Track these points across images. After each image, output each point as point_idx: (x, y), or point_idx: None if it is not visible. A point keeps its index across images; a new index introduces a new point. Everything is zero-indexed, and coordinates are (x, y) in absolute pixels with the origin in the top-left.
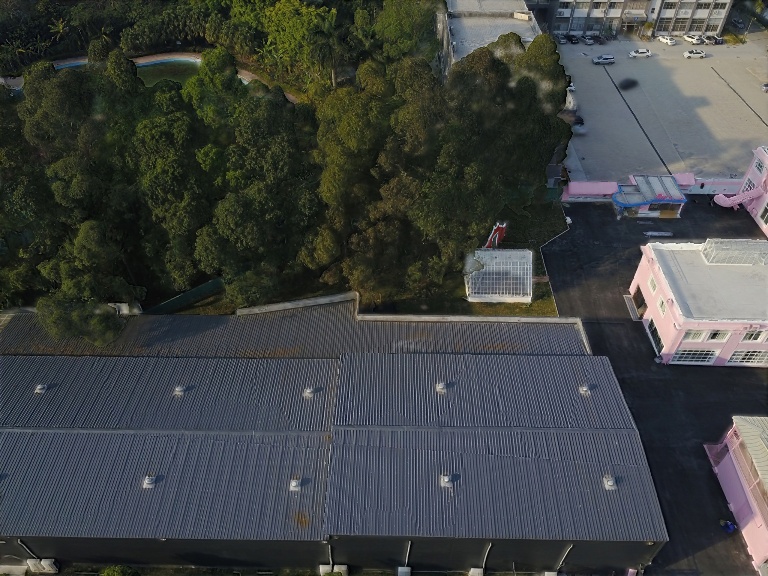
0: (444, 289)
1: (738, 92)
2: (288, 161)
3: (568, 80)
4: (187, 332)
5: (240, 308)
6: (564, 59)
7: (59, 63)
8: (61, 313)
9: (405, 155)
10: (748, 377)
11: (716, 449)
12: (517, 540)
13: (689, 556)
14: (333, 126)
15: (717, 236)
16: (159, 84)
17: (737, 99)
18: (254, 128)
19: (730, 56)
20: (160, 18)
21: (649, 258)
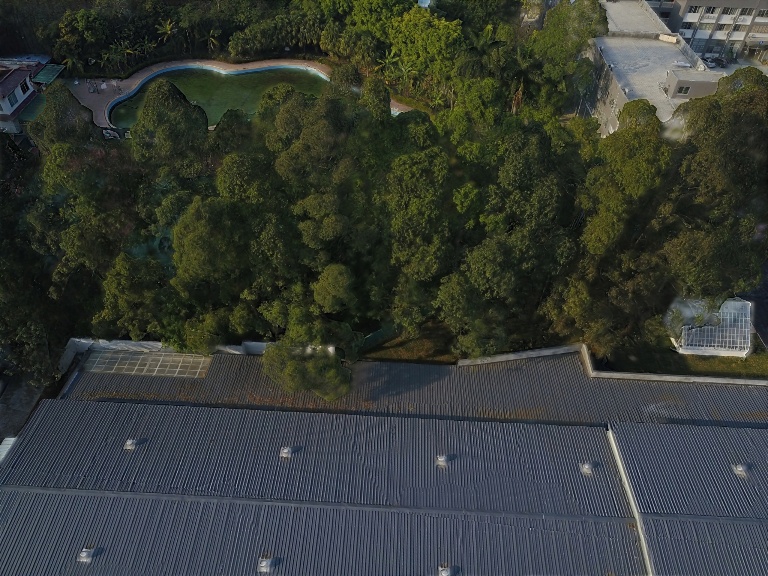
0: None
1: None
2: (555, 206)
3: None
4: (410, 384)
5: (463, 358)
6: None
7: (165, 66)
8: (295, 364)
9: (679, 204)
10: None
11: None
12: None
13: None
14: (610, 170)
15: None
16: (412, 115)
17: None
18: (524, 169)
19: None
20: (273, 23)
21: None
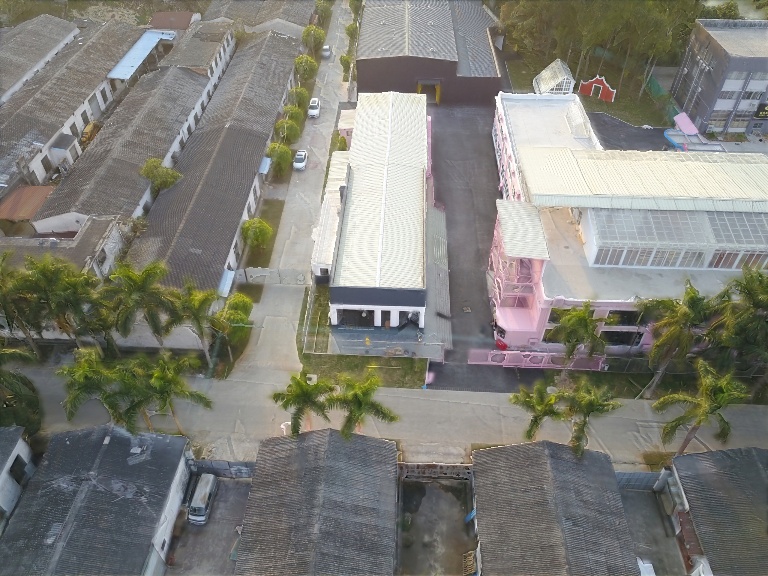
0: None
1: None
2: None
3: None
4: None
5: None
6: None
7: None
8: None
9: None
10: (488, 161)
11: None
12: None
13: None
14: None
15: None
16: None
17: None
18: None
19: None
20: None
21: None
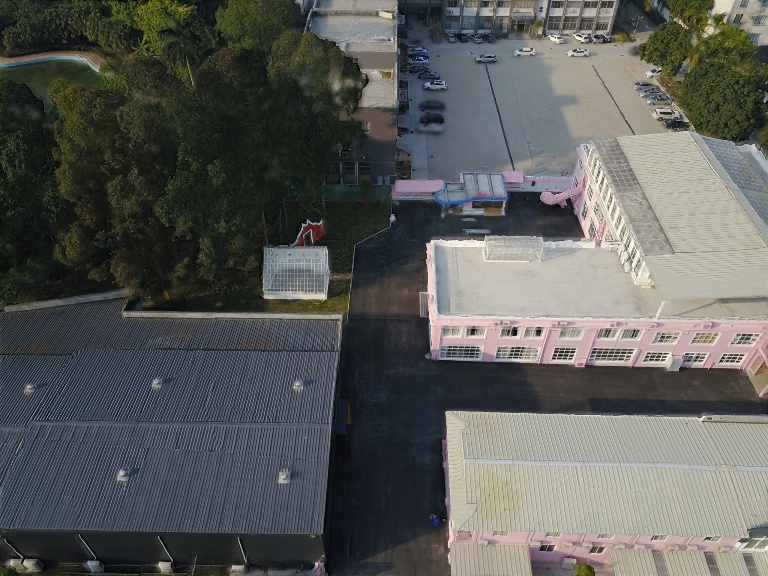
0: (245, 286)
1: (610, 90)
2: (24, 158)
3: (365, 78)
4: None
5: (7, 305)
6: (448, 57)
7: None
8: None
9: (145, 152)
10: (513, 373)
11: None
12: (175, 533)
13: (388, 549)
14: None
15: (535, 233)
16: None
17: (607, 97)
18: None
19: (614, 54)
20: (42, 17)
21: (429, 255)
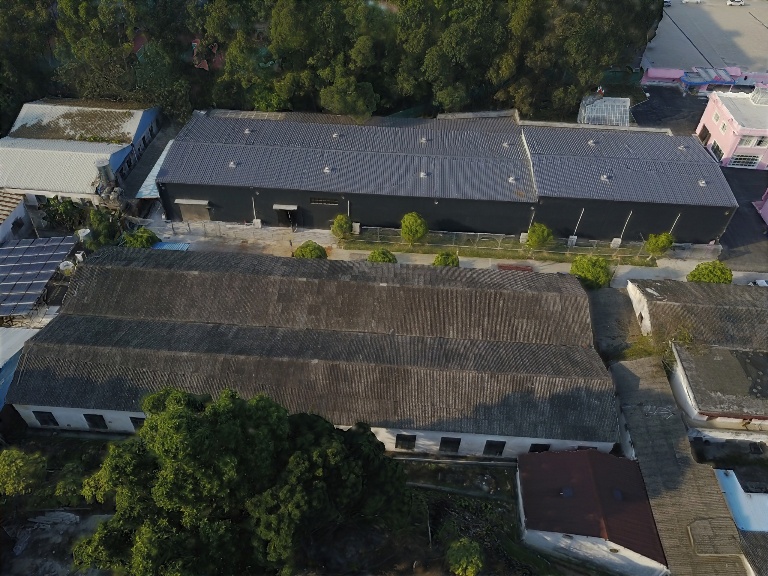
0: None
1: None
2: (493, 4)
3: None
4: (408, 124)
5: (440, 113)
6: None
7: None
8: (340, 97)
9: (566, 5)
10: None
11: (760, 203)
12: (650, 204)
13: (744, 245)
14: None
15: None
16: None
17: None
18: None
19: (764, 6)
20: None
21: (714, 100)
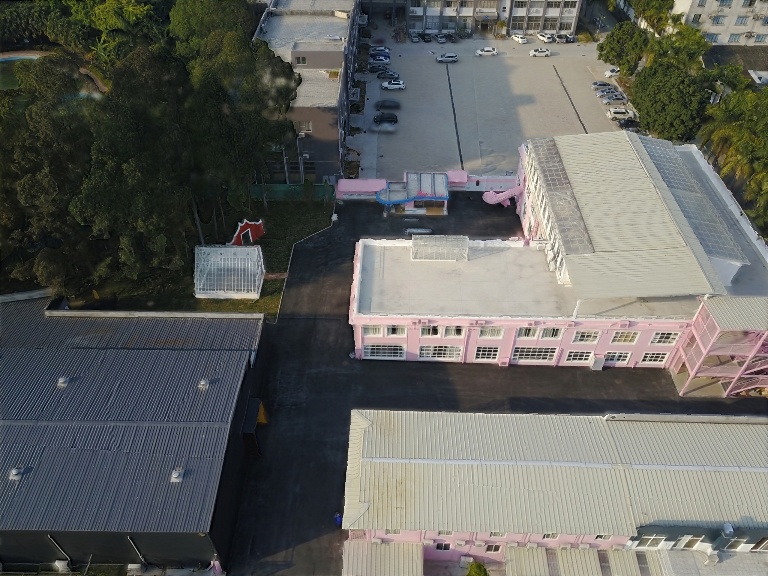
0: (179, 285)
1: (568, 90)
2: None
3: (298, 77)
4: None
5: None
6: (410, 57)
7: None
8: None
9: (59, 151)
10: (436, 372)
11: None
12: None
13: (289, 548)
14: None
15: (475, 233)
16: None
17: (564, 97)
18: None
19: (576, 54)
20: (3, 16)
21: None
